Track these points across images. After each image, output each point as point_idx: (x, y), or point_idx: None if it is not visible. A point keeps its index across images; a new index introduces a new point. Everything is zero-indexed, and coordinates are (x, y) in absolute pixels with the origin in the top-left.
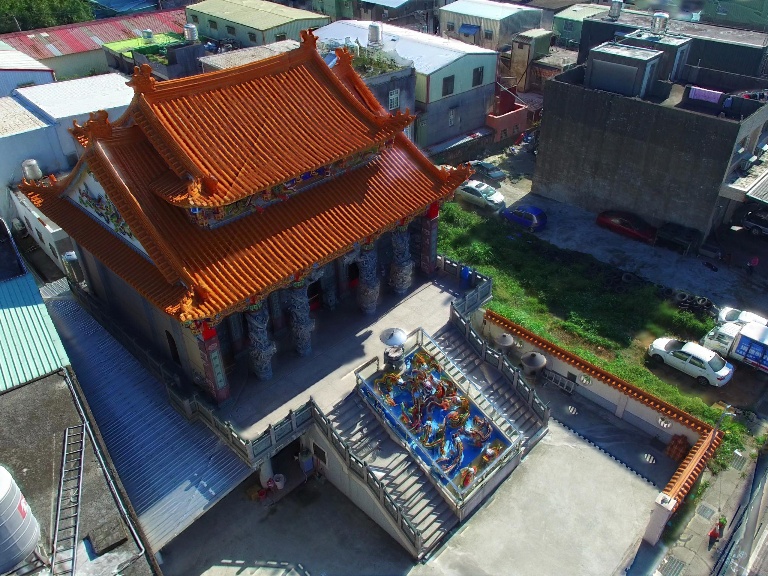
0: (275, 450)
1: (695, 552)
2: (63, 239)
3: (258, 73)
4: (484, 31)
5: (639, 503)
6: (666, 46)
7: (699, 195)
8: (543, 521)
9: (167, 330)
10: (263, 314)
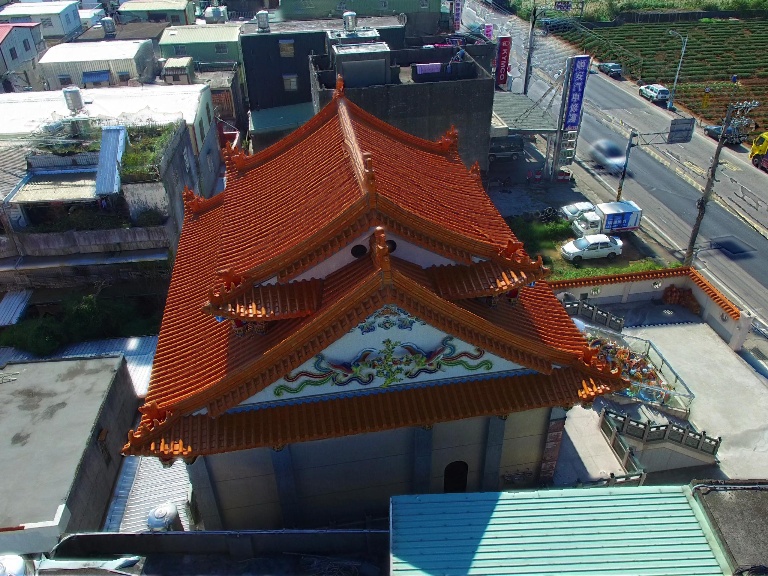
0: None
1: (750, 339)
2: (67, 524)
3: None
4: (117, 74)
5: (705, 336)
6: (371, 38)
7: (477, 143)
8: (704, 384)
9: (455, 461)
10: None
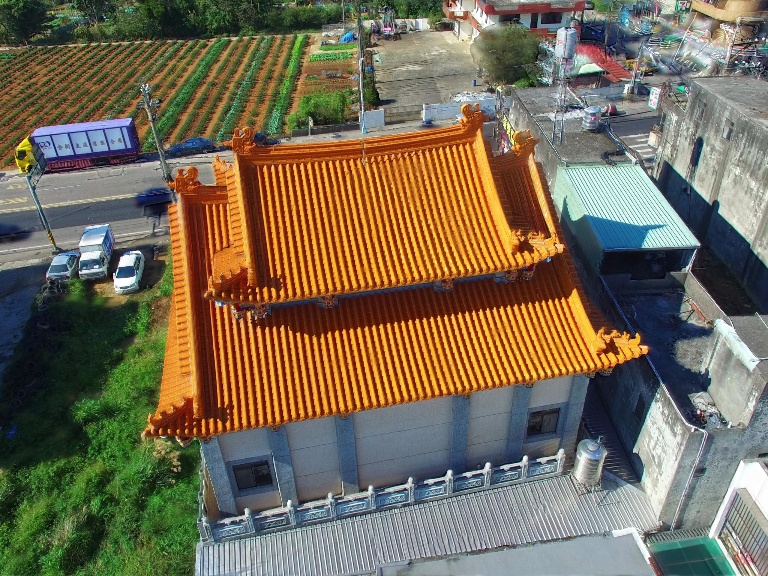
0: None
1: None
2: None
3: None
4: None
5: None
6: None
7: None
8: None
9: None
10: None
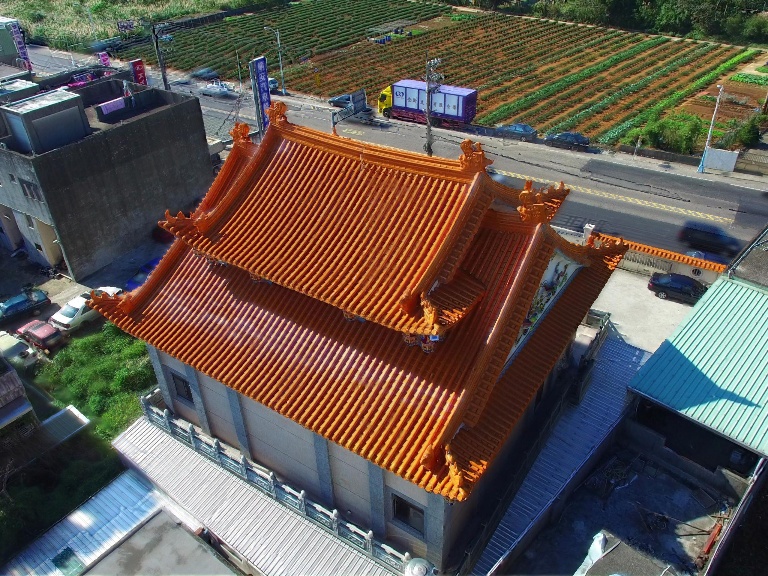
0: None
1: None
2: None
3: None
4: None
5: None
6: (30, 90)
7: (201, 165)
8: None
9: None
10: None
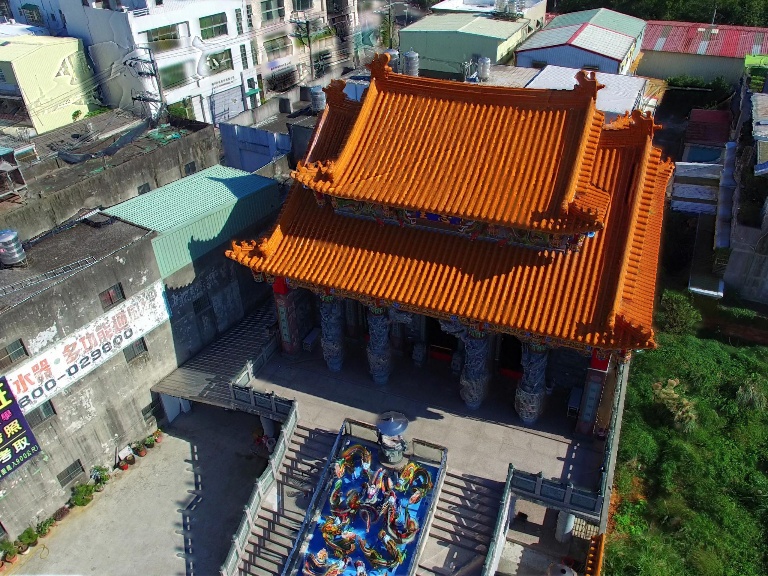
0: (252, 409)
1: None
2: None
3: (504, 100)
4: None
5: None
6: None
7: None
8: None
9: None
10: (331, 309)
